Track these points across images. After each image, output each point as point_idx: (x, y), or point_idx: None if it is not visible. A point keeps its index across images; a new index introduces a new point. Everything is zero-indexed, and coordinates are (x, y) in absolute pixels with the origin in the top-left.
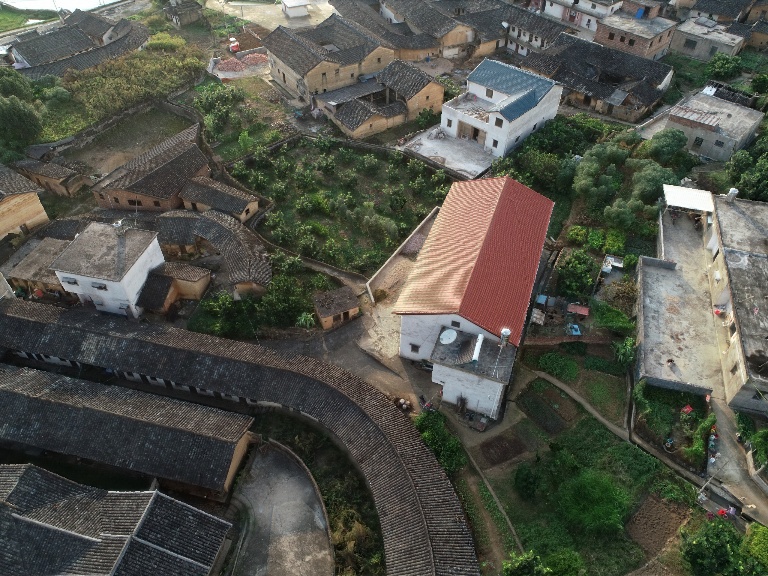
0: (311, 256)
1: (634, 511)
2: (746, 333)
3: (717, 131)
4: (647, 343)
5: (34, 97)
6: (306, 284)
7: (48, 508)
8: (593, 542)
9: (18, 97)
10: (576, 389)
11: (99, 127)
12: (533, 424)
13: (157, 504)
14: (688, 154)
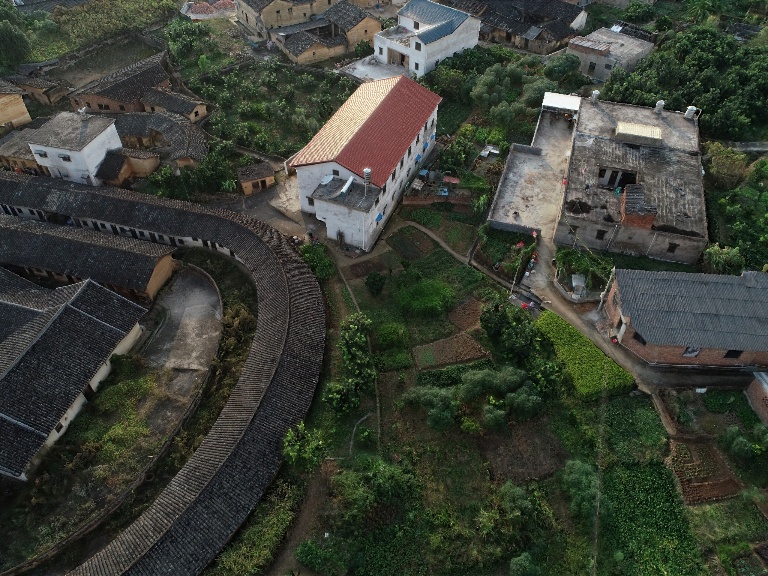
0: (244, 146)
1: (458, 305)
2: (572, 187)
3: (607, 56)
4: (501, 202)
5: (27, 28)
6: (237, 165)
7: (8, 295)
8: (419, 321)
9: (12, 25)
10: (437, 233)
11: (81, 53)
12: (396, 254)
13: (89, 288)
14: (581, 76)
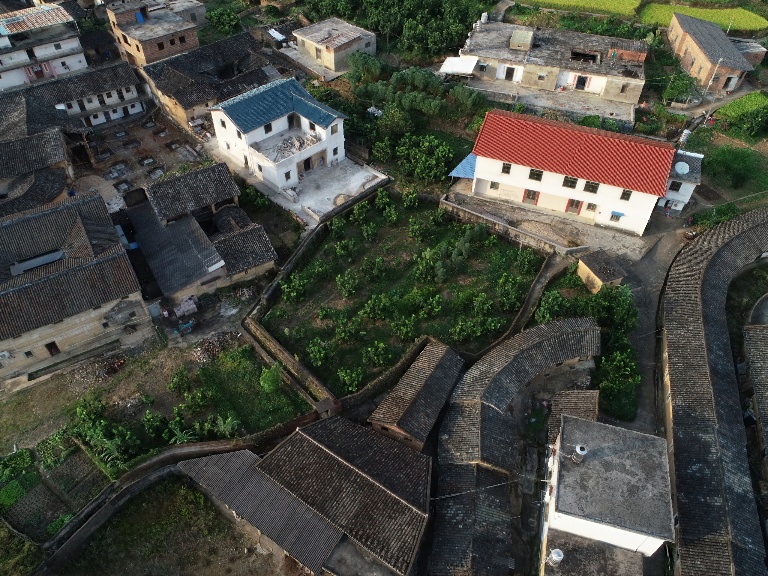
0: None
1: None
2: (606, 73)
3: None
4: None
5: None
6: None
7: None
8: None
9: None
10: None
11: None
12: None
13: None
14: None
